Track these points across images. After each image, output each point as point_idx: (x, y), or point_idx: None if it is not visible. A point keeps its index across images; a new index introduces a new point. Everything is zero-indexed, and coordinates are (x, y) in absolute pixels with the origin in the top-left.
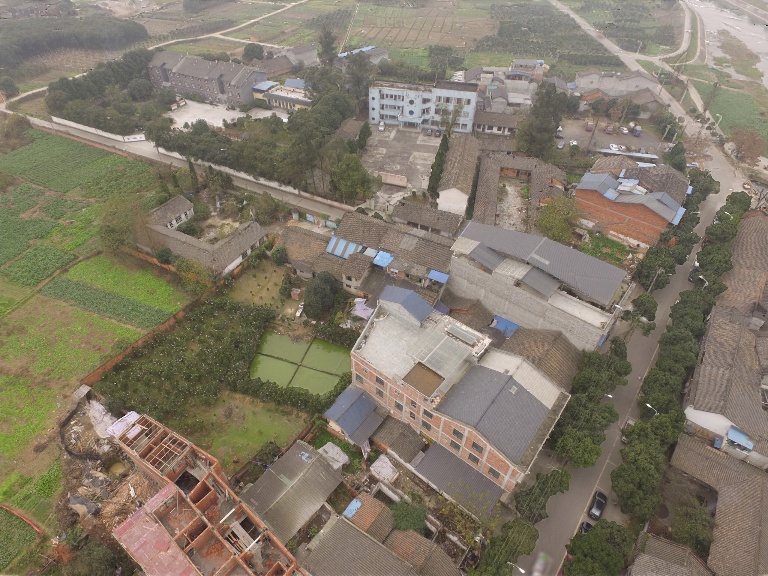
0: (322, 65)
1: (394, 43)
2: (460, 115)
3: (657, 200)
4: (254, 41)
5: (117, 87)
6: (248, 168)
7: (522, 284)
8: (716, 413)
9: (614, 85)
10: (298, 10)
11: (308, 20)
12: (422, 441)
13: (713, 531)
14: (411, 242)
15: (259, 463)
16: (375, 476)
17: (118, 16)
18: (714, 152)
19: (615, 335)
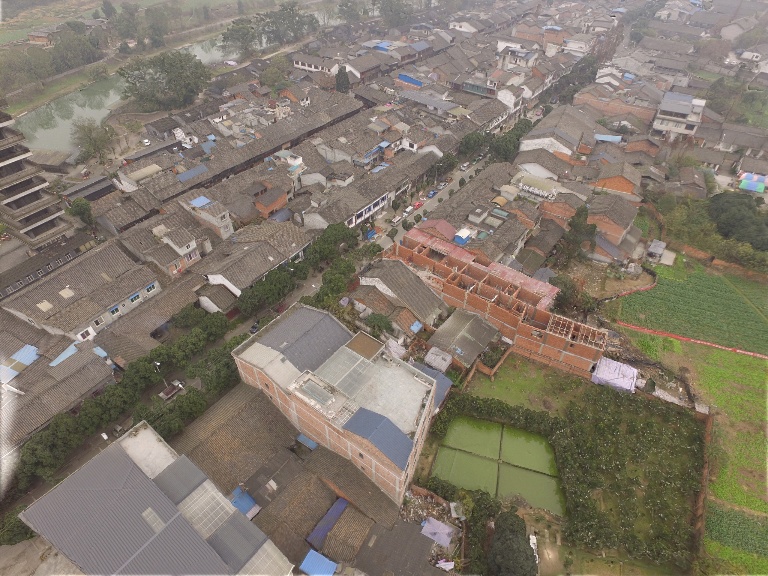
0: None
1: None
2: None
3: None
4: None
5: None
6: None
7: None
8: None
9: None
10: None
11: None
12: None
13: None
14: None
15: None
16: None
17: None
18: None
19: None
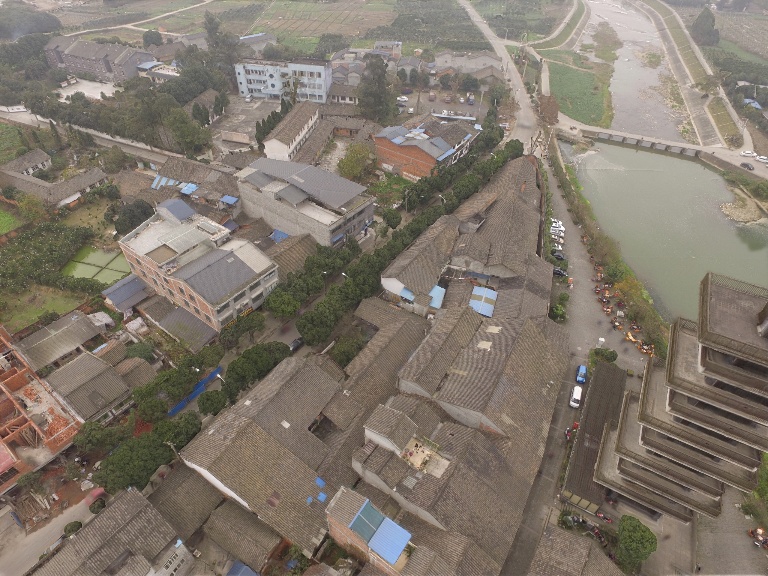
0: (190, 44)
1: (294, 33)
2: (315, 87)
3: (430, 143)
4: (162, 31)
5: (7, 65)
6: (106, 128)
7: None
8: (392, 277)
9: (465, 64)
10: (216, 5)
11: (219, 13)
12: (174, 308)
13: (361, 350)
14: (215, 176)
15: (41, 326)
16: (130, 332)
17: (40, 10)
18: (529, 116)
19: (371, 243)
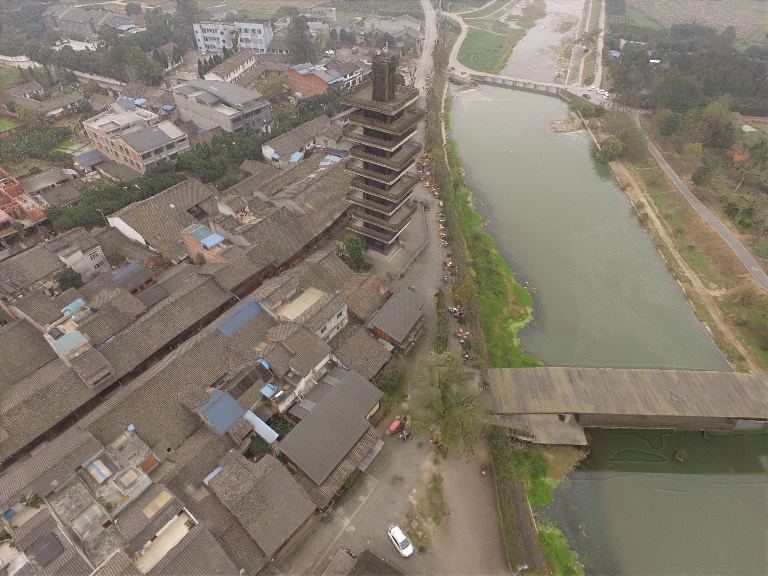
0: None
1: (258, 6)
2: (257, 42)
3: (325, 72)
4: (144, 5)
5: (12, 26)
6: (86, 68)
7: (200, 101)
8: (266, 145)
9: (389, 26)
10: None
11: None
12: None
13: None
14: (160, 93)
15: None
16: None
17: None
18: (429, 63)
19: None
